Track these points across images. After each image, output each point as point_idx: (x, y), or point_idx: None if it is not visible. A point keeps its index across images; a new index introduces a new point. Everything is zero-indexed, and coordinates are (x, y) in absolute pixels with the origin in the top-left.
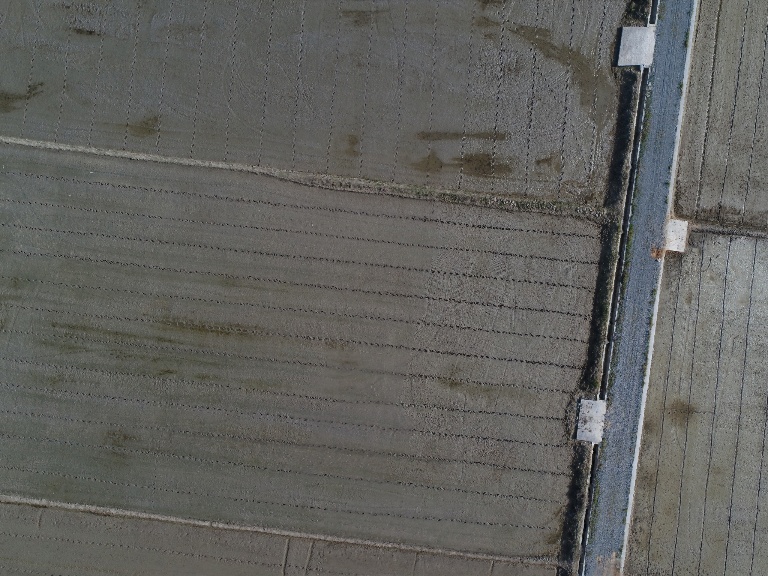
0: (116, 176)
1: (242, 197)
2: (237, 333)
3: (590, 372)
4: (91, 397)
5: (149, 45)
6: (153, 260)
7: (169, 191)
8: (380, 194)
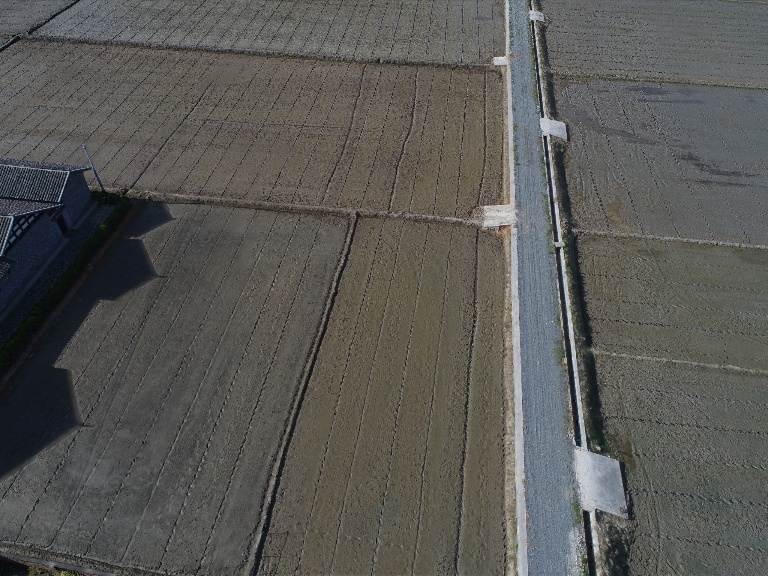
0: None
1: None
2: None
3: None
4: None
5: None
6: None
7: None
8: None
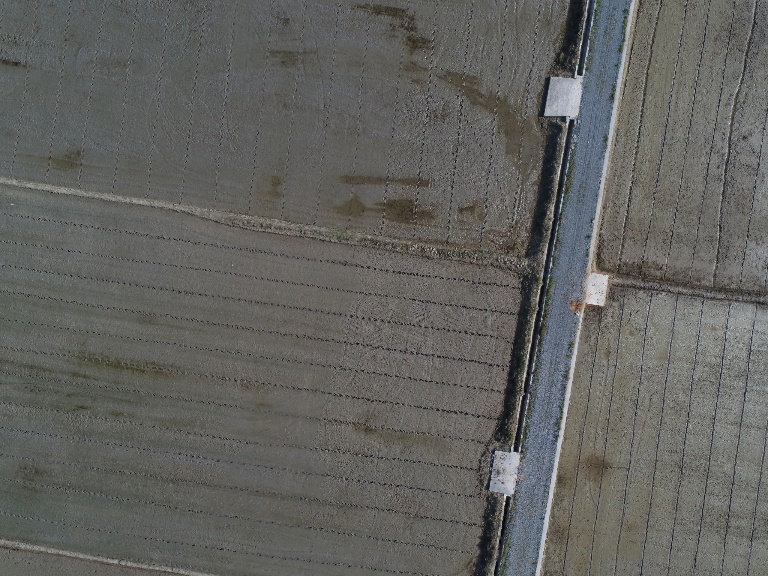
0: (37, 209)
1: (162, 235)
2: (152, 371)
3: (505, 423)
4: (4, 430)
5: (74, 78)
6: (71, 295)
7: (89, 226)
8: (301, 236)
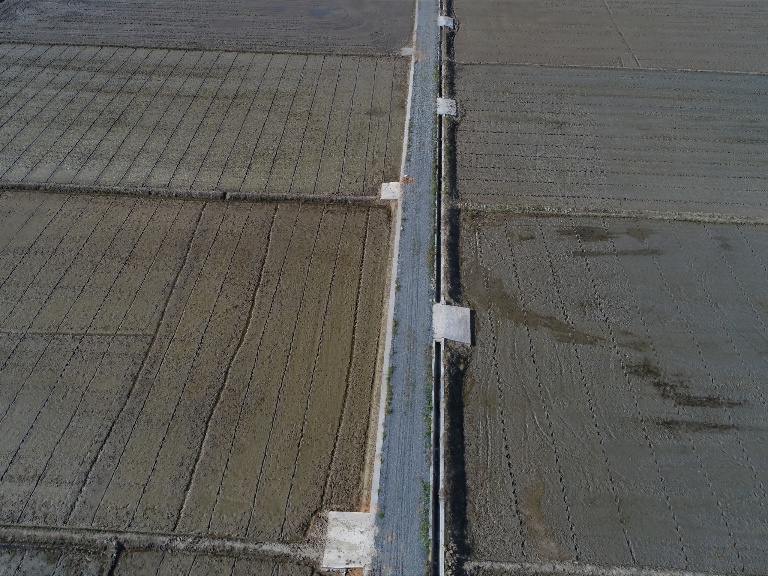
0: None
1: None
2: (744, 140)
3: None
4: None
5: None
6: None
7: None
8: None
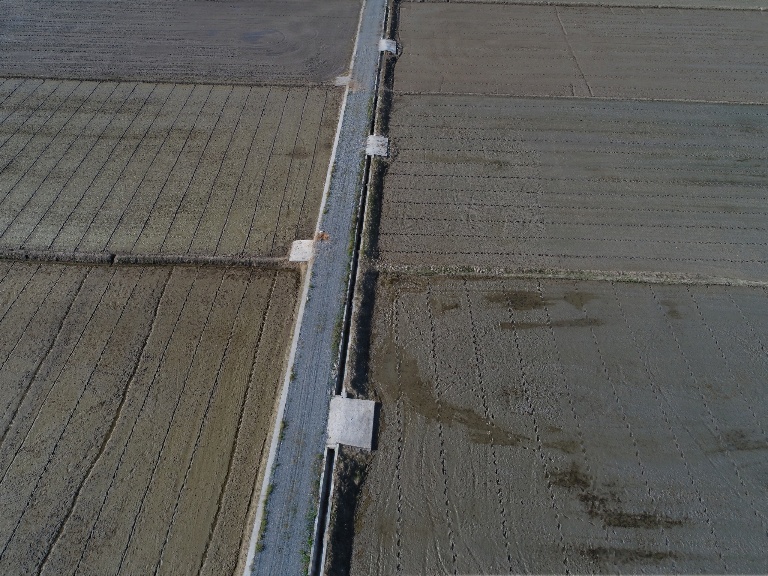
0: None
1: (762, 264)
2: (700, 182)
3: (381, 169)
4: None
5: None
6: None
7: None
8: None
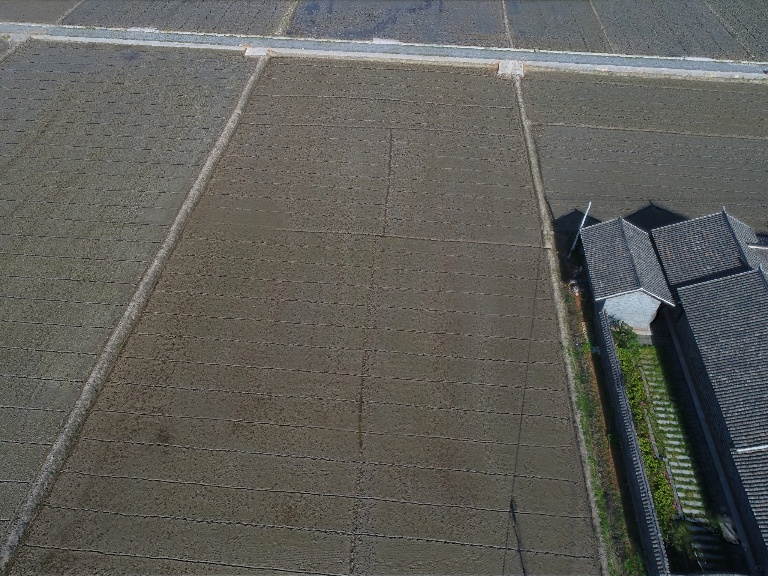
0: None
1: None
2: None
3: None
4: None
5: None
6: None
7: None
8: None
